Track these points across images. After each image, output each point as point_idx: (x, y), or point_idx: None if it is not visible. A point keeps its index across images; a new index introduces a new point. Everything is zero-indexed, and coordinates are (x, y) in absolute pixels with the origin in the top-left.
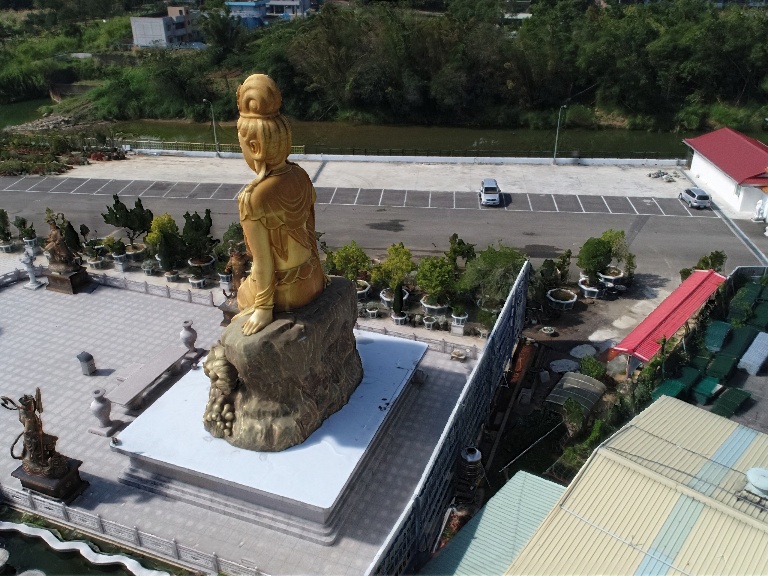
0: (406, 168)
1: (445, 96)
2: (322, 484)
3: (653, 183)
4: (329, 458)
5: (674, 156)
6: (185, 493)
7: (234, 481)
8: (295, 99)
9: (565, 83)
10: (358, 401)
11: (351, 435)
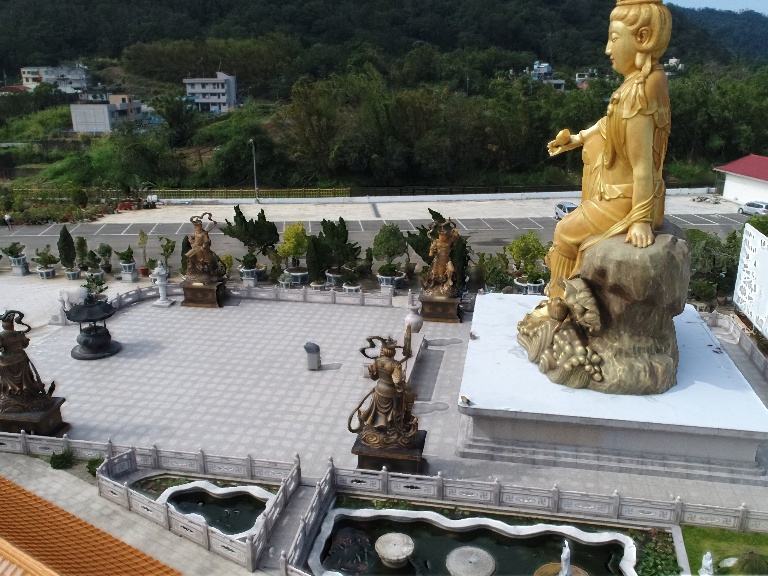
0: (460, 204)
1: (430, 161)
2: (746, 414)
3: (703, 205)
4: (722, 394)
5: (704, 185)
6: (558, 456)
7: (648, 421)
8: (275, 170)
9: (536, 148)
10: (685, 349)
11: (718, 374)
